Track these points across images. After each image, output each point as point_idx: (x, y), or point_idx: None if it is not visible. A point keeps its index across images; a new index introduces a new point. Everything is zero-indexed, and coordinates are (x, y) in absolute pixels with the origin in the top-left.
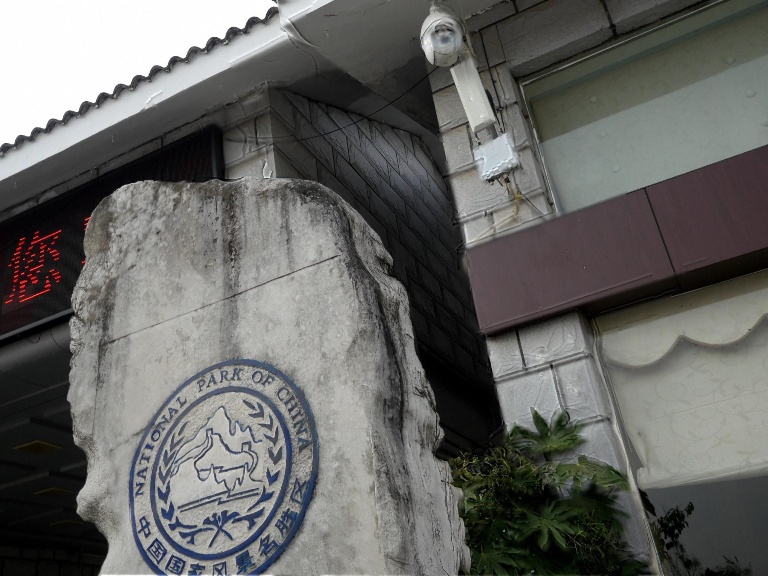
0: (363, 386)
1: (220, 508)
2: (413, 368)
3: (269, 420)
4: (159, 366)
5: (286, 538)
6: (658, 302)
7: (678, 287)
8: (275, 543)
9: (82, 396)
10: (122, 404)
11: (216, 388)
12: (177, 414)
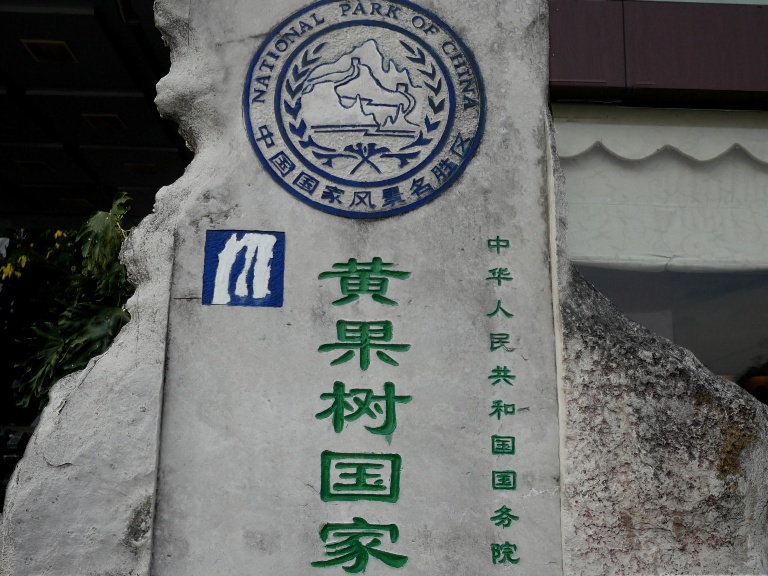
0: (540, 67)
1: (367, 140)
2: None
3: (431, 69)
4: None
5: (443, 185)
6: (606, 108)
7: (626, 100)
8: (431, 186)
9: None
10: None
11: (365, 18)
12: (311, 31)
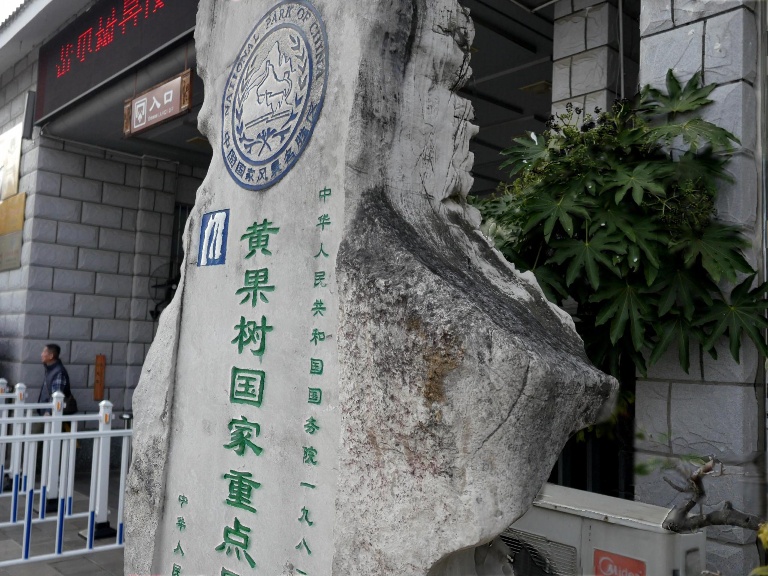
0: (364, 19)
1: (267, 126)
2: (442, 7)
3: (302, 52)
4: (246, 7)
5: (300, 150)
6: None
7: None
8: (293, 154)
9: (203, 35)
10: (223, 41)
11: (276, 25)
12: (252, 49)
